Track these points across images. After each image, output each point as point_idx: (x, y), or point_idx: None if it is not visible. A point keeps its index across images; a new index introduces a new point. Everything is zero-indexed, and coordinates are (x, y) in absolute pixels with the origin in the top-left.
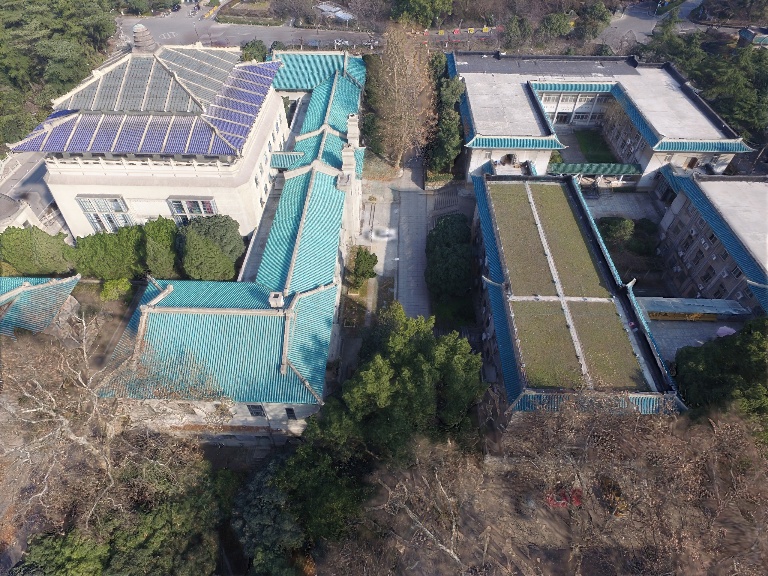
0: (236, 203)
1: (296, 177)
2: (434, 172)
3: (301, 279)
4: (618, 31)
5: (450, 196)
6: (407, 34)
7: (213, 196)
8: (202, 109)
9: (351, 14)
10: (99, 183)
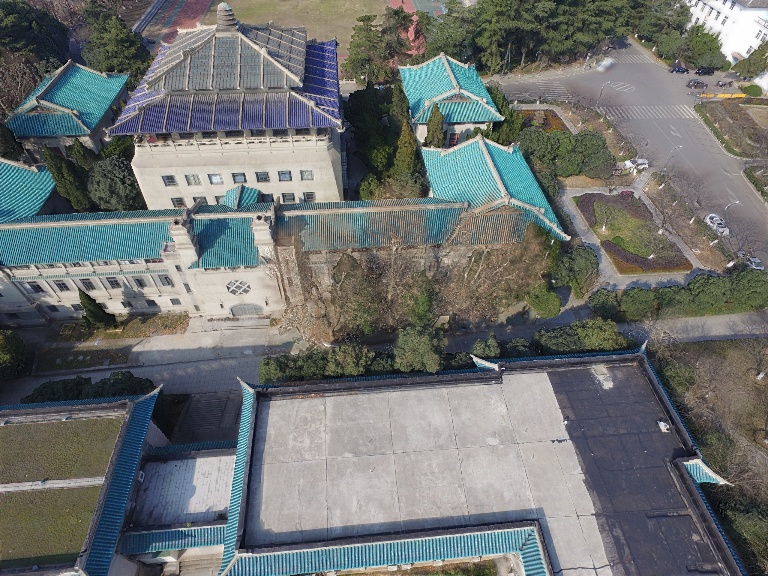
0: None
1: None
2: None
3: (3, 237)
4: None
5: None
6: None
7: None
8: None
9: None
10: None
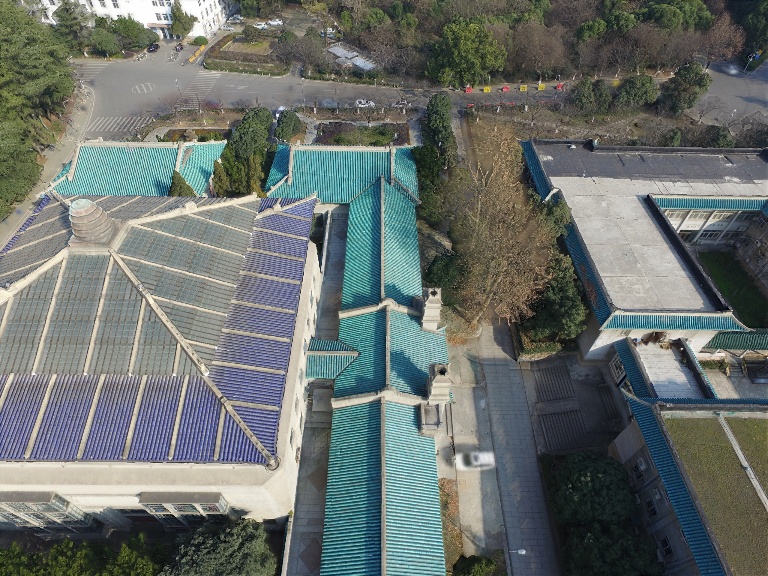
0: (260, 496)
1: (351, 407)
2: (532, 338)
3: None
4: (722, 101)
5: (559, 378)
6: (444, 90)
7: (220, 492)
8: (201, 372)
9: (371, 61)
10: (11, 481)
